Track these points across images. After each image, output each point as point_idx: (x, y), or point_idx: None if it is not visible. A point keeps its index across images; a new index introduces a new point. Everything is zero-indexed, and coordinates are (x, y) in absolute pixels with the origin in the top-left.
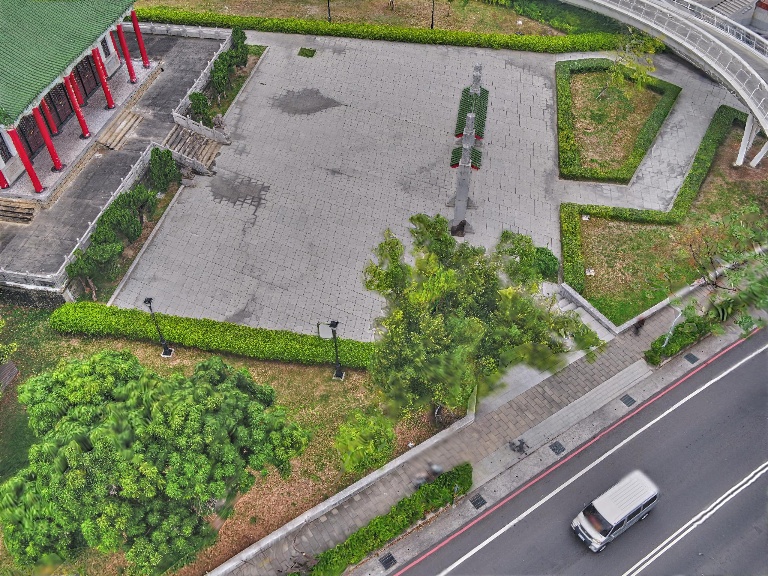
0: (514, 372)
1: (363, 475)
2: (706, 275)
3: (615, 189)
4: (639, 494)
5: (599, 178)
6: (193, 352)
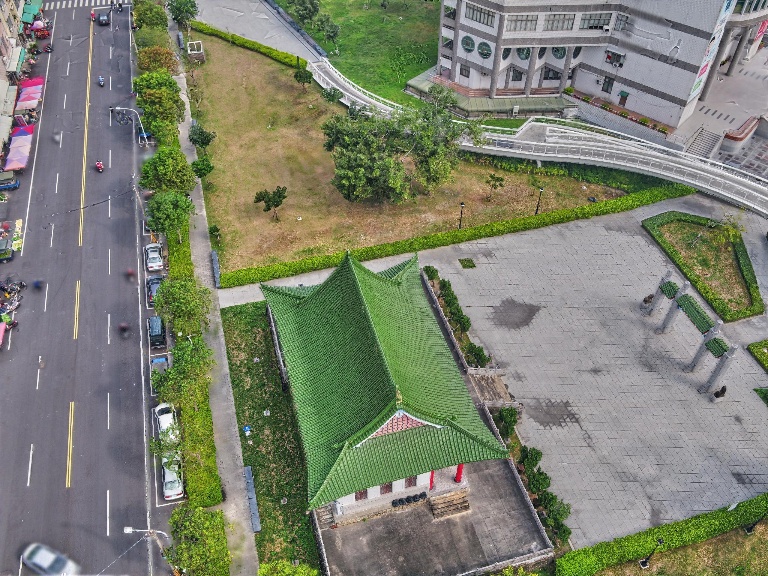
0: None
1: None
2: None
3: (760, 320)
4: None
5: (748, 315)
6: (656, 556)
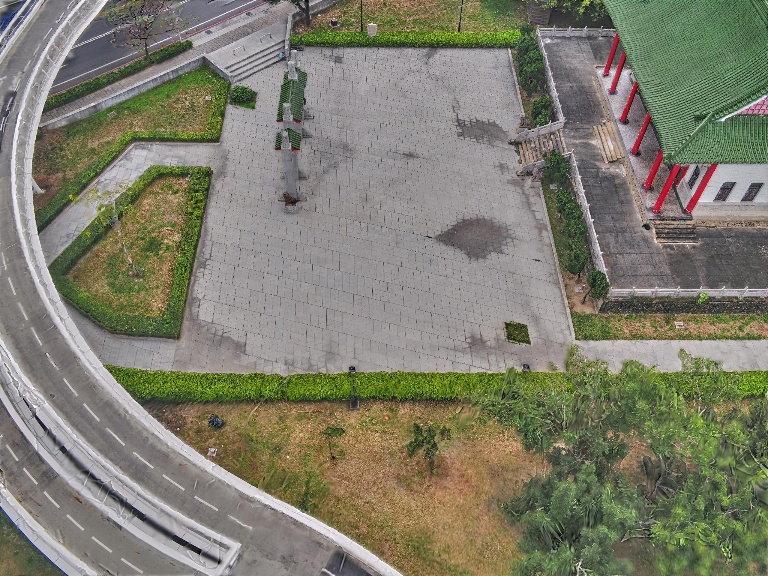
0: (267, 36)
1: (340, 6)
2: (156, 12)
3: None
4: (216, 2)
5: None
6: None
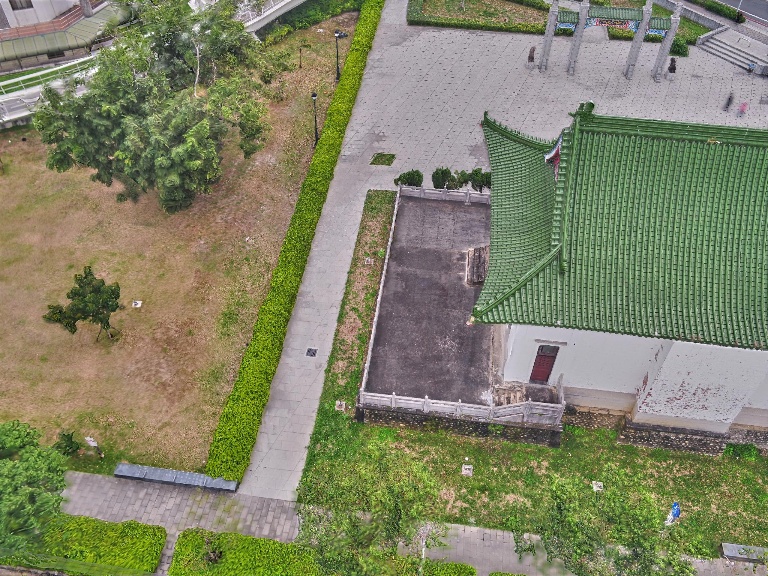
0: None
1: None
2: None
3: None
4: None
5: None
6: None
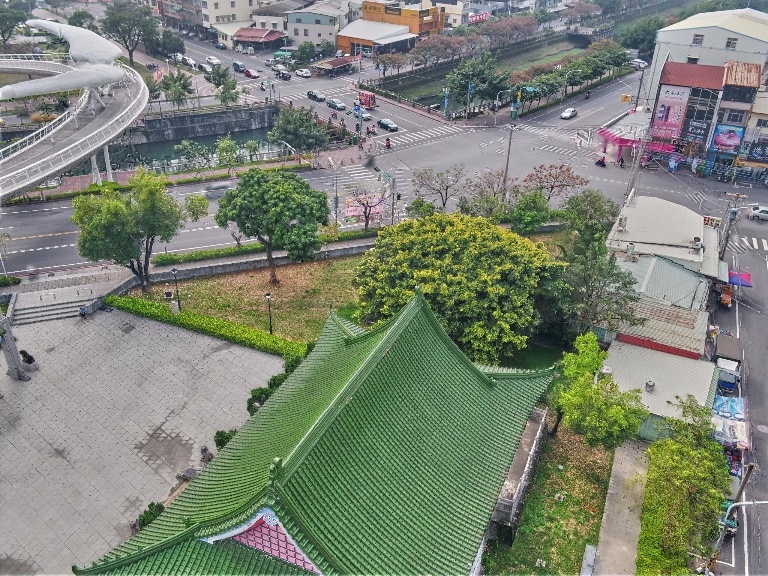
0: None
1: (197, 280)
2: None
3: None
4: None
5: None
6: None
